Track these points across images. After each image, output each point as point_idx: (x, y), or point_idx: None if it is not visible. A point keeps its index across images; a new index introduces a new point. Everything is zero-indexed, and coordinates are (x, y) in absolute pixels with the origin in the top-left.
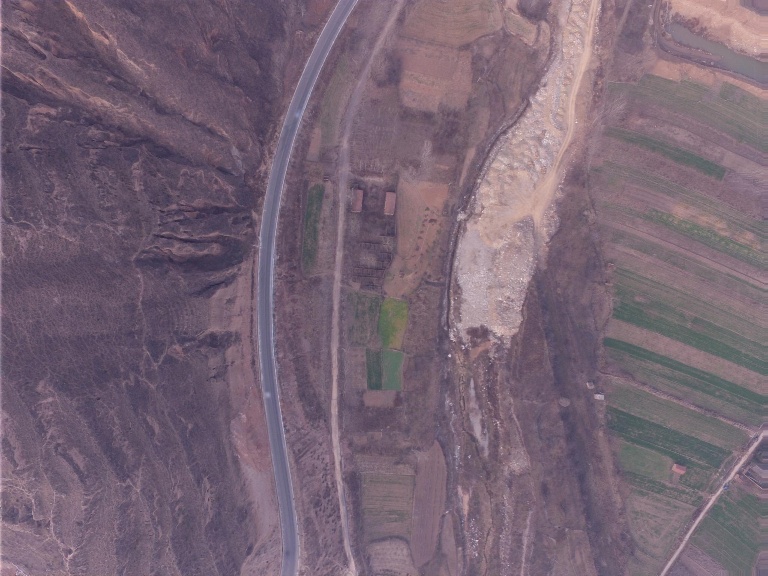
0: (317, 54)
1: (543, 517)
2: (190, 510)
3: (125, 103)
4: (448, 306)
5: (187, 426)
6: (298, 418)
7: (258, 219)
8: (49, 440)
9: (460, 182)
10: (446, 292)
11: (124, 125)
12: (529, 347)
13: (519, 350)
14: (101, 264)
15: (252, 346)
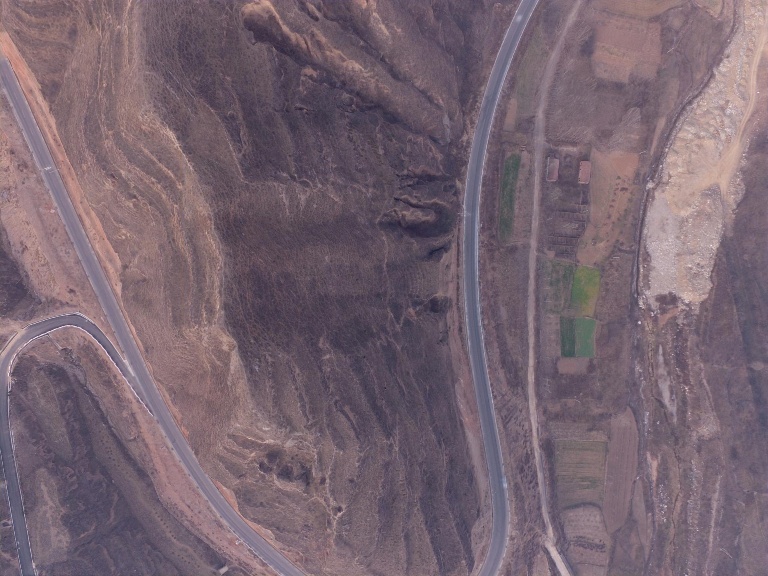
0: (515, 26)
1: (732, 481)
2: (432, 471)
3: (372, 67)
4: (637, 274)
5: (426, 388)
6: (502, 385)
7: (462, 188)
8: (331, 396)
9: (651, 151)
10: (636, 260)
11: (363, 90)
12: (719, 312)
13: (709, 316)
14: (356, 225)
15: (459, 313)
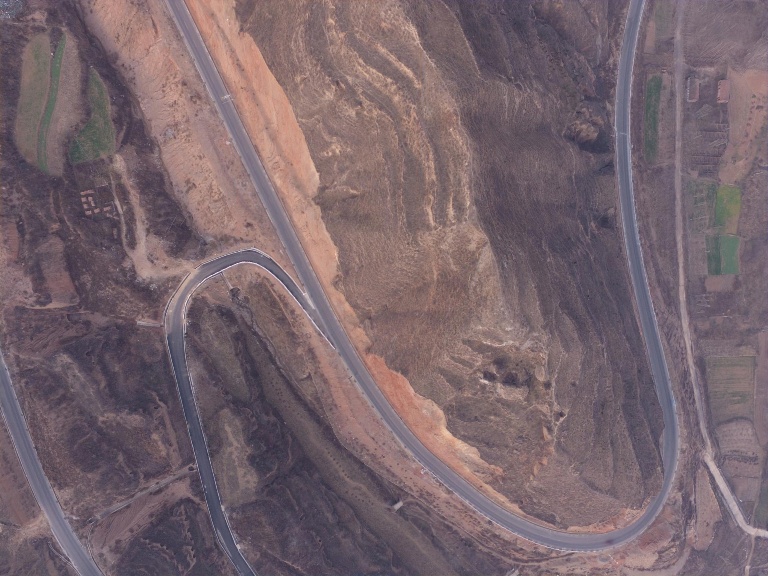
0: None
1: None
2: (627, 380)
3: None
4: None
5: None
6: (660, 303)
7: (612, 110)
8: None
9: None
10: None
11: (538, 5)
12: None
13: None
14: (551, 135)
15: None
